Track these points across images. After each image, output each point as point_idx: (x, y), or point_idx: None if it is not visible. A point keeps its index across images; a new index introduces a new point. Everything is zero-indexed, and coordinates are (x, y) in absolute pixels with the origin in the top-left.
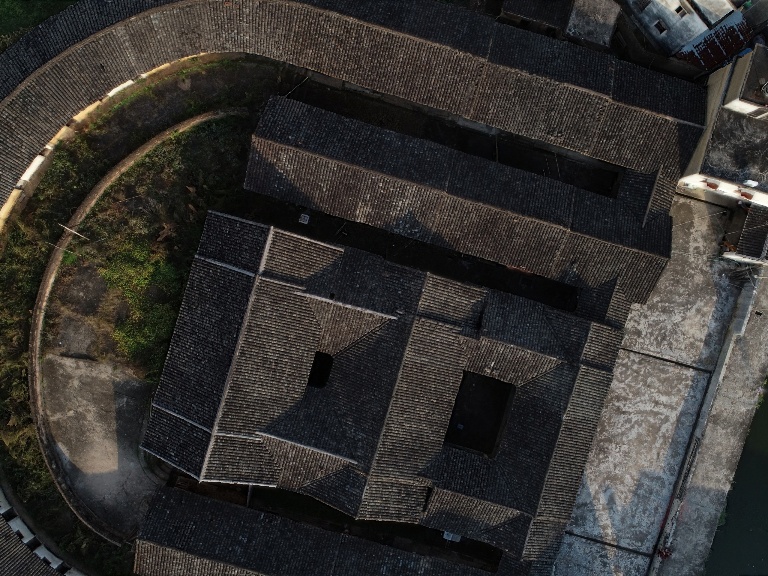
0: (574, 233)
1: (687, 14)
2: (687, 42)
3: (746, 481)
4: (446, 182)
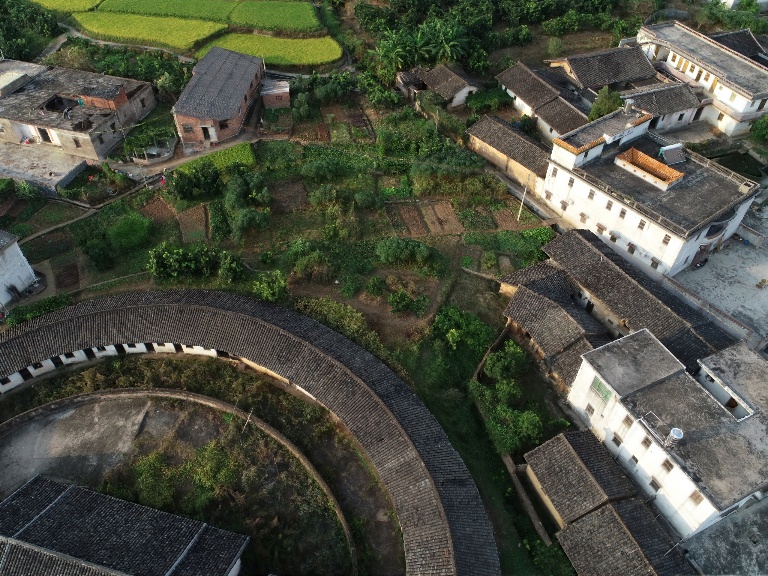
0: None
1: None
2: None
3: None
4: None
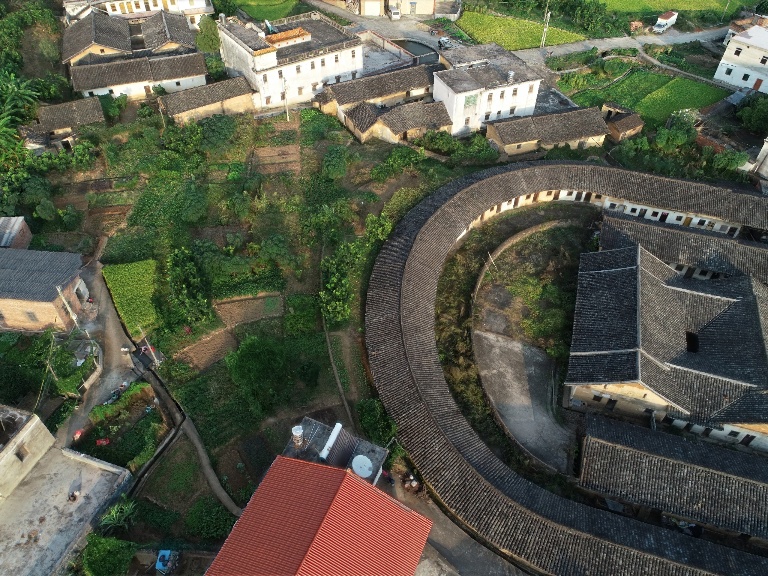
0: None
1: None
2: None
3: None
4: None
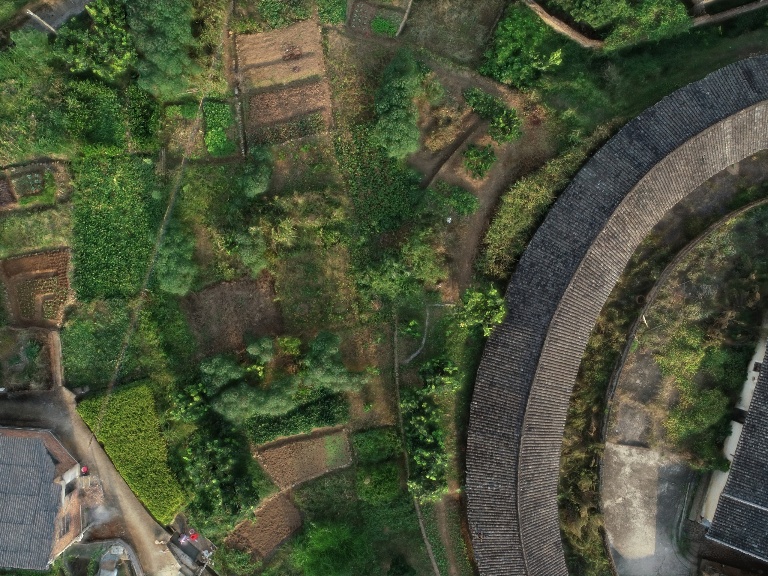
0: None
1: None
2: None
3: None
4: None
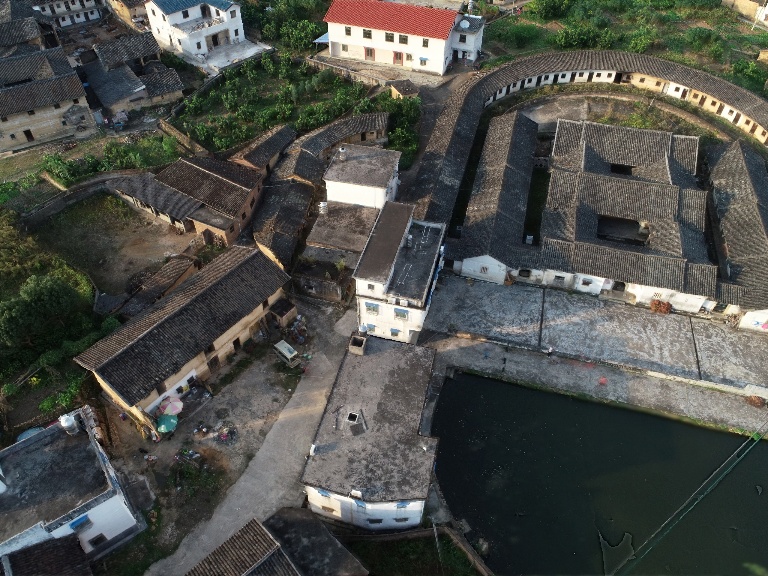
0: None
1: None
2: None
3: (620, 415)
4: (763, 204)
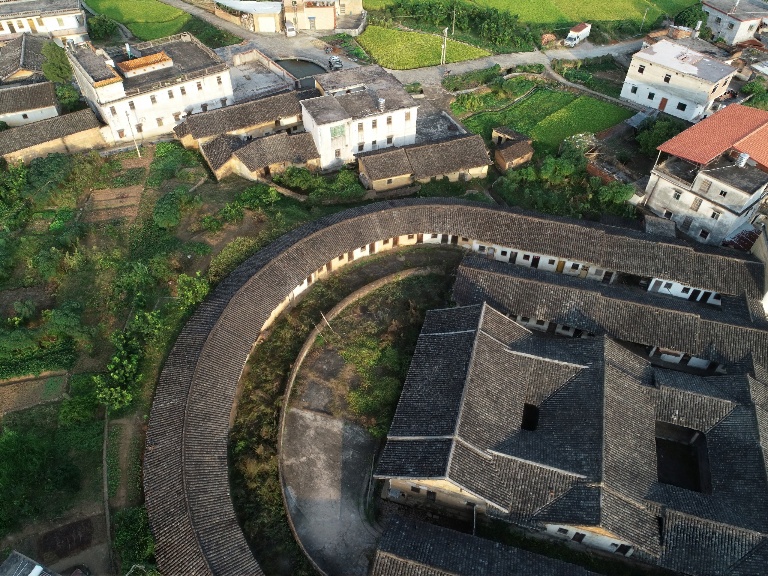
0: (703, 320)
1: (720, 215)
2: (726, 235)
3: None
4: (598, 291)
